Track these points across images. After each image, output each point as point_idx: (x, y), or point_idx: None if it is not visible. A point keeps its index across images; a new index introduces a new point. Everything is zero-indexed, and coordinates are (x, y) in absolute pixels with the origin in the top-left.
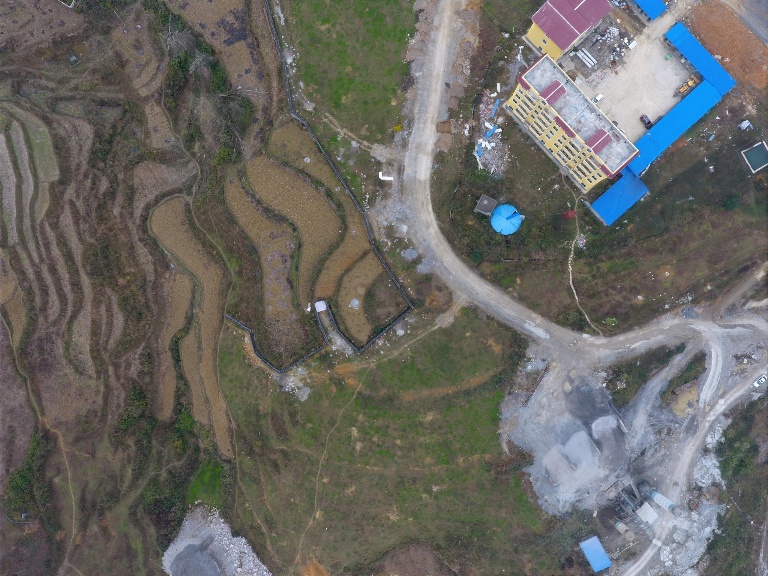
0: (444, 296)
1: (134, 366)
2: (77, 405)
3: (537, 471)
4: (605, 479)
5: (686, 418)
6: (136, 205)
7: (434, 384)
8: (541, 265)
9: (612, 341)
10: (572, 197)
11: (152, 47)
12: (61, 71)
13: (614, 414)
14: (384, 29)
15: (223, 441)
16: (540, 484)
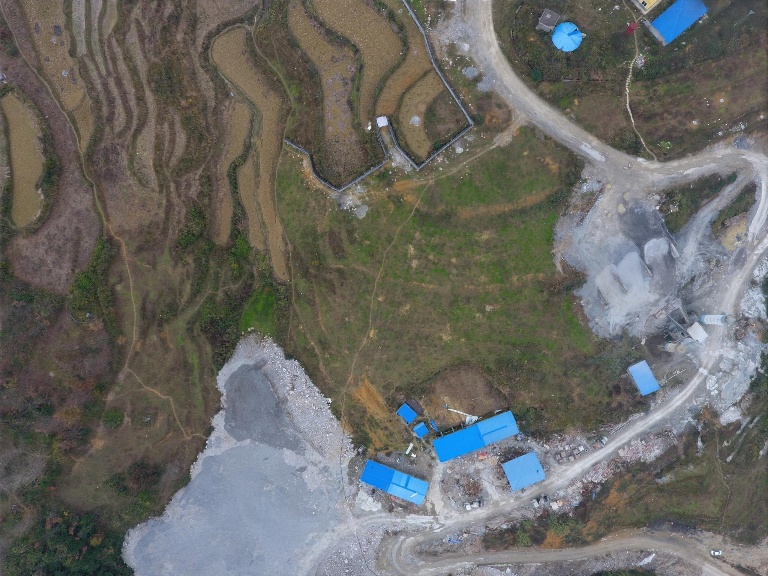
0: (504, 113)
1: (194, 187)
2: (140, 215)
3: (589, 293)
4: (655, 303)
5: (734, 251)
6: (198, 33)
7: (491, 201)
8: (599, 86)
9: (666, 166)
10: (632, 18)
11: None
12: None
13: (666, 237)
14: None
15: (279, 265)
16: (591, 307)
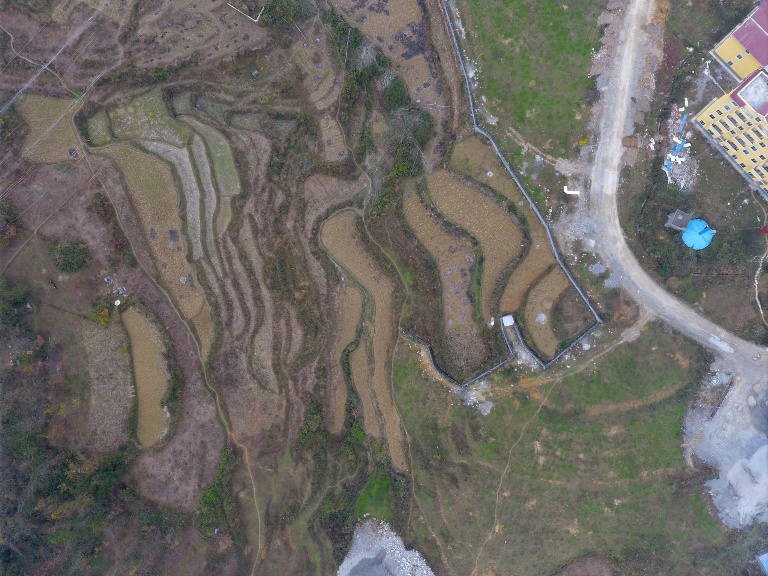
0: (632, 310)
1: (310, 380)
2: (262, 420)
3: (719, 485)
4: None
5: None
6: (307, 218)
7: (621, 398)
8: (728, 279)
9: None
10: (762, 212)
11: (330, 60)
12: (242, 85)
13: None
14: (568, 43)
15: (397, 454)
16: (721, 497)
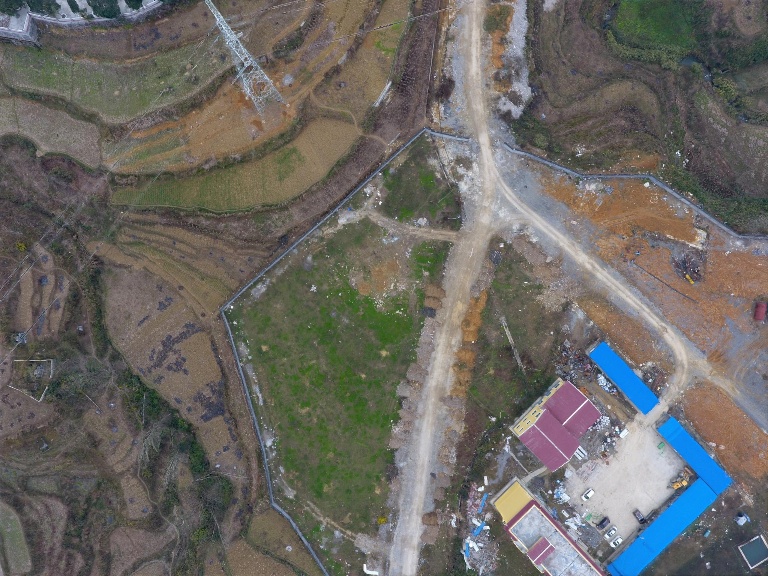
0: None
1: None
2: None
3: None
4: None
5: None
6: (113, 573)
7: None
8: None
9: None
10: None
11: (126, 424)
12: (32, 457)
13: None
14: (366, 415)
15: None
16: None
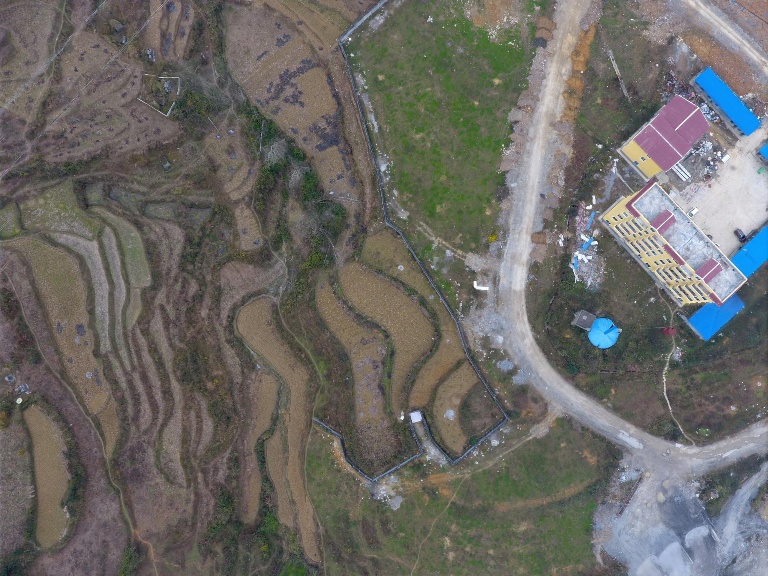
0: (540, 408)
1: (222, 471)
2: (168, 515)
3: None
4: None
5: None
6: (223, 306)
7: (529, 495)
8: (636, 376)
9: (704, 450)
10: (668, 310)
11: (244, 152)
12: (154, 176)
13: (707, 524)
14: (479, 139)
15: (310, 545)
16: None
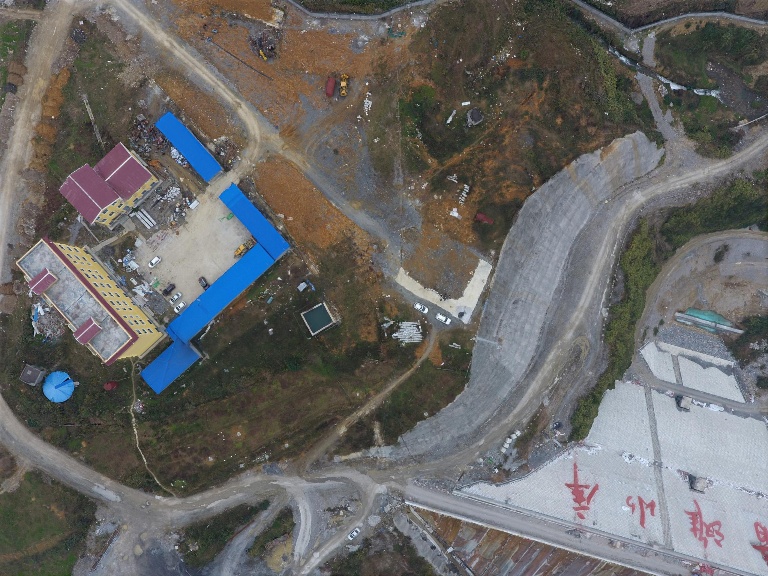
0: (4, 462)
1: None
2: None
3: None
4: None
5: (280, 572)
6: None
7: None
8: (105, 429)
9: (187, 502)
10: (129, 362)
11: None
12: None
13: None
14: None
15: None
16: None
